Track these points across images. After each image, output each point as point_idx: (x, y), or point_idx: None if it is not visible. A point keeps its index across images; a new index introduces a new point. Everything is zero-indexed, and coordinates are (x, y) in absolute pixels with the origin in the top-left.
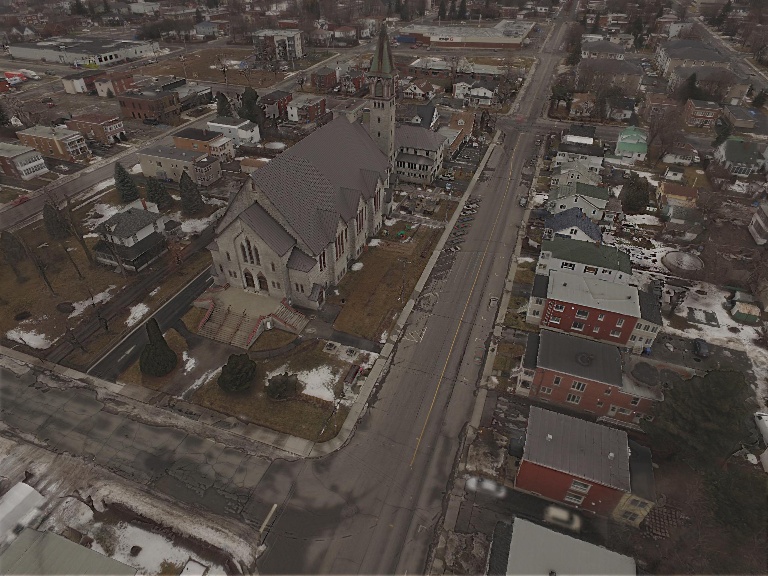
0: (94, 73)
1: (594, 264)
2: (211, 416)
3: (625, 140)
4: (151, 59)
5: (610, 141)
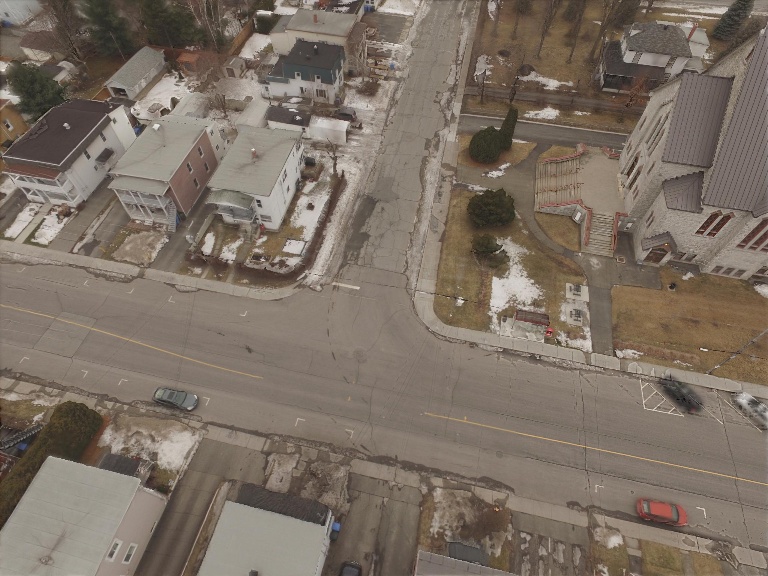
0: None
1: None
2: (441, 211)
3: None
4: None
5: None
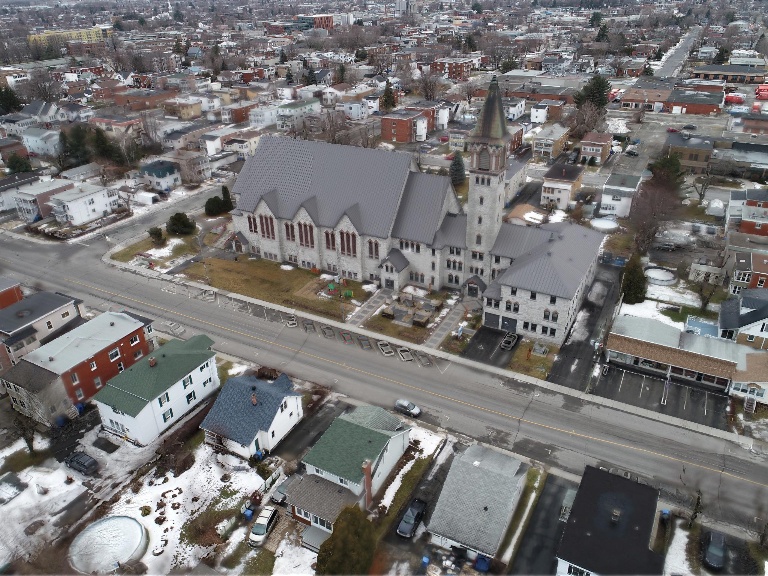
0: (762, 117)
1: None
2: None
3: None
4: None
5: None
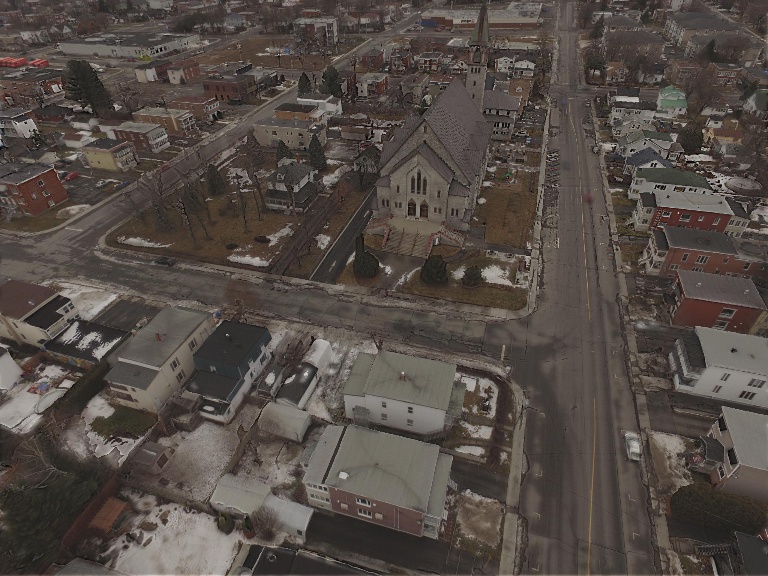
0: (163, 63)
1: (682, 184)
2: (424, 300)
3: (667, 97)
4: (196, 50)
5: (649, 101)
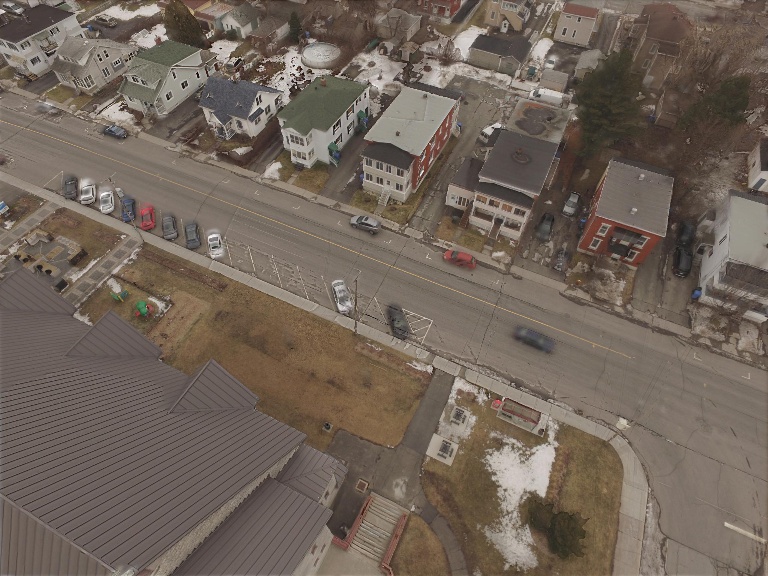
0: None
1: (350, 103)
2: None
3: None
4: None
5: None
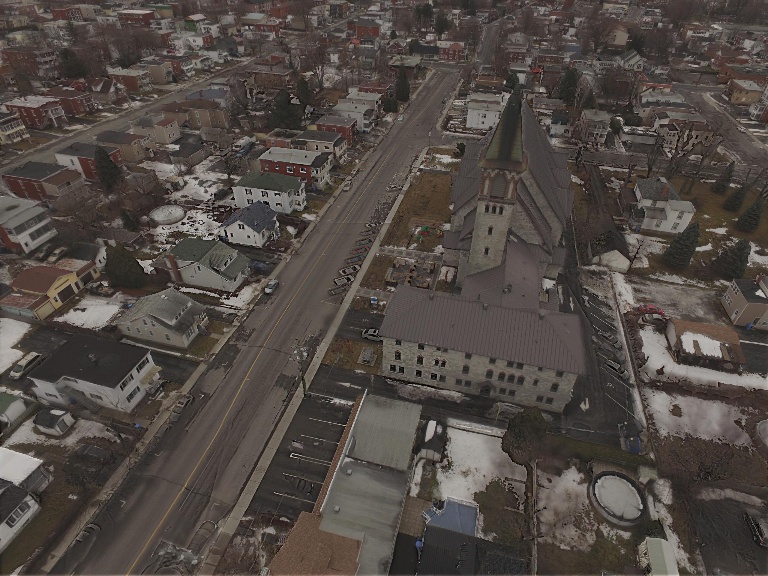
0: None
1: None
2: None
3: None
4: None
5: None
